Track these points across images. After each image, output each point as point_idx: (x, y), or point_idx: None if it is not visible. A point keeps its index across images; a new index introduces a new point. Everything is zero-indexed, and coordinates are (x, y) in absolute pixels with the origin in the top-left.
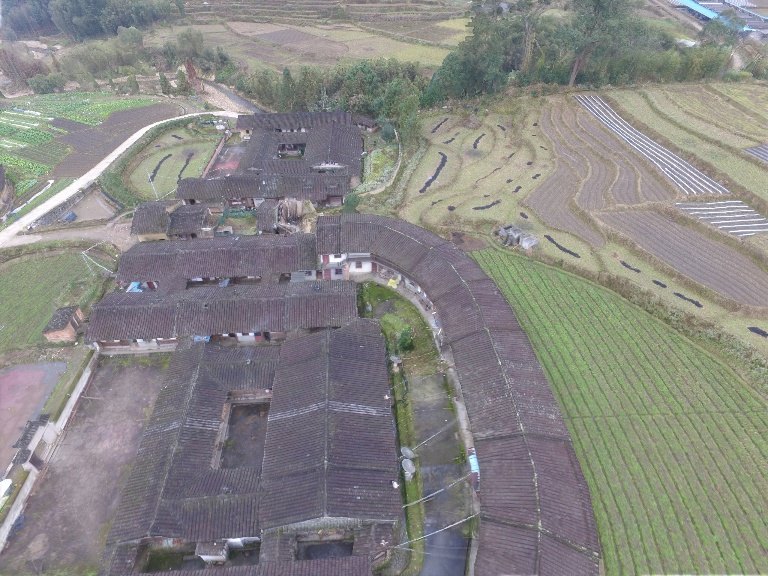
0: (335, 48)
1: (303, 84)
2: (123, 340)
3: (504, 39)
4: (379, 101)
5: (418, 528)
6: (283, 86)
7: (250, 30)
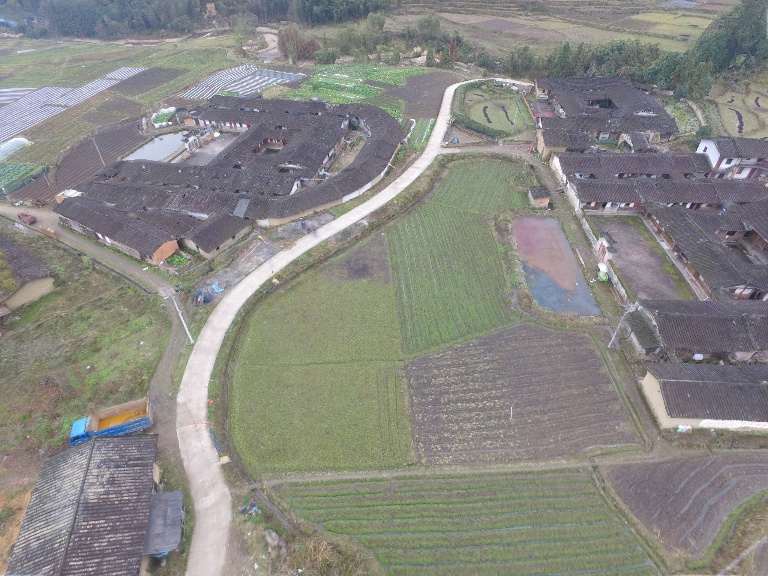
0: (552, 34)
1: (576, 57)
2: (597, 205)
3: None
4: (653, 70)
5: None
6: (562, 57)
7: (462, 19)
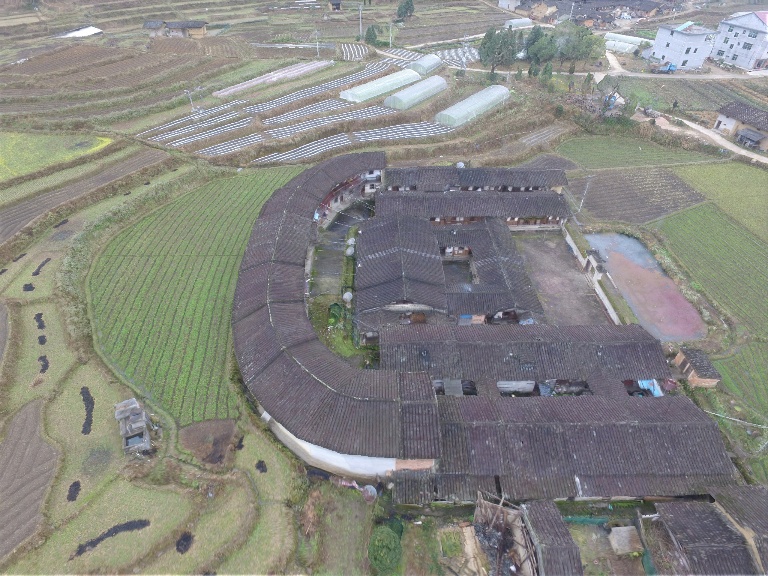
0: None
1: None
2: None
3: None
4: None
5: (350, 236)
6: None
7: None
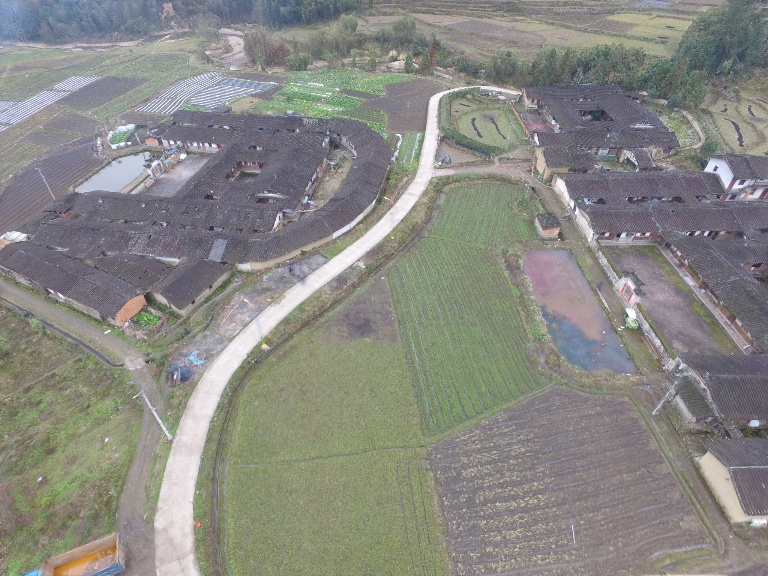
0: (531, 37)
1: (563, 63)
2: (612, 235)
3: (706, 30)
4: (643, 78)
5: None
6: (548, 64)
7: (437, 21)
